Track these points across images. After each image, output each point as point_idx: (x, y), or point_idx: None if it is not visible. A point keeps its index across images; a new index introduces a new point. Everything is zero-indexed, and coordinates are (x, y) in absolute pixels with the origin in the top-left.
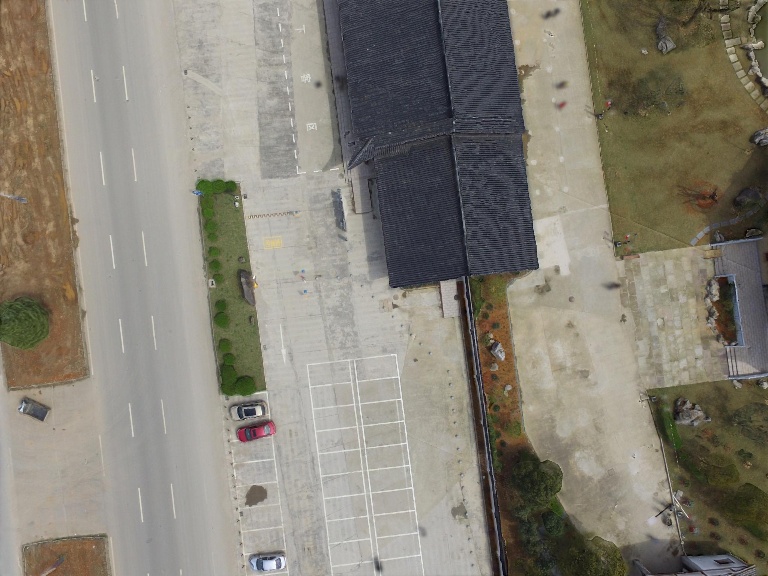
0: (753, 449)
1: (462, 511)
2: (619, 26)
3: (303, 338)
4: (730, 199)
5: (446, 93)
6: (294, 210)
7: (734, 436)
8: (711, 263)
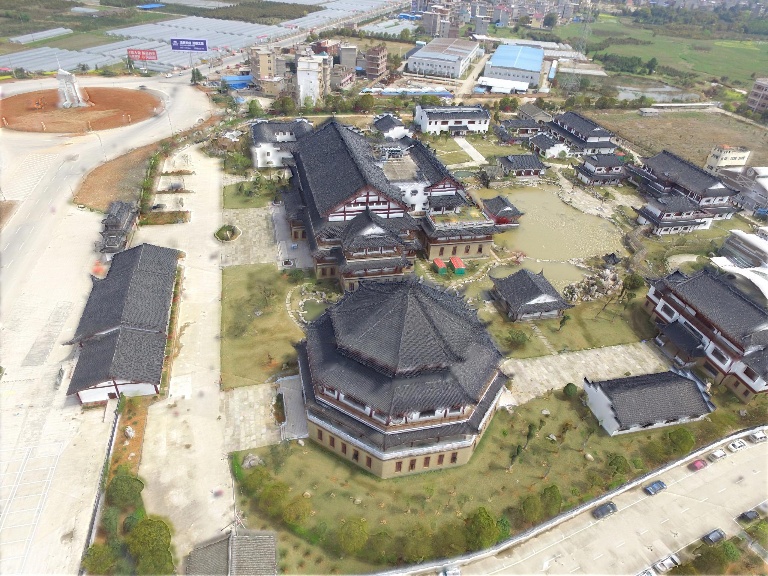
0: (294, 480)
1: (70, 537)
2: (238, 309)
3: (2, 437)
4: (286, 363)
5: None
6: (33, 378)
7: (282, 473)
8: (275, 390)
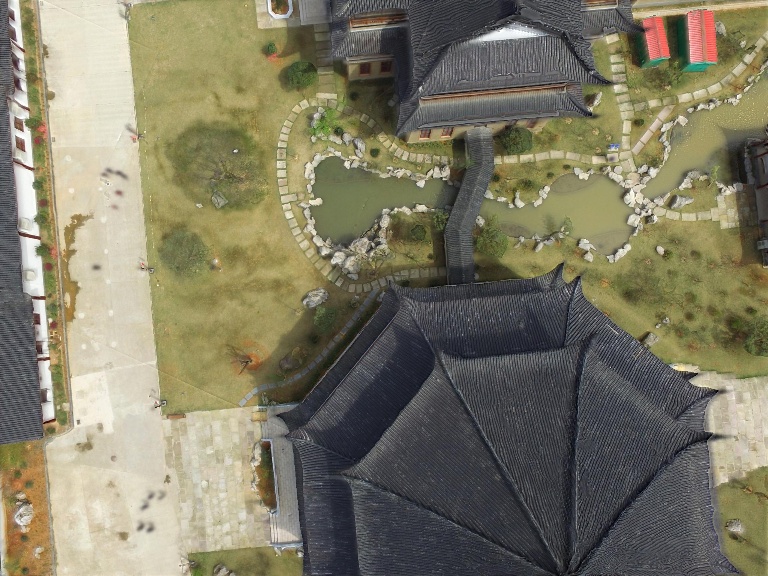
0: None
1: None
2: (176, 177)
3: None
4: (277, 361)
5: None
6: None
7: None
8: (258, 425)
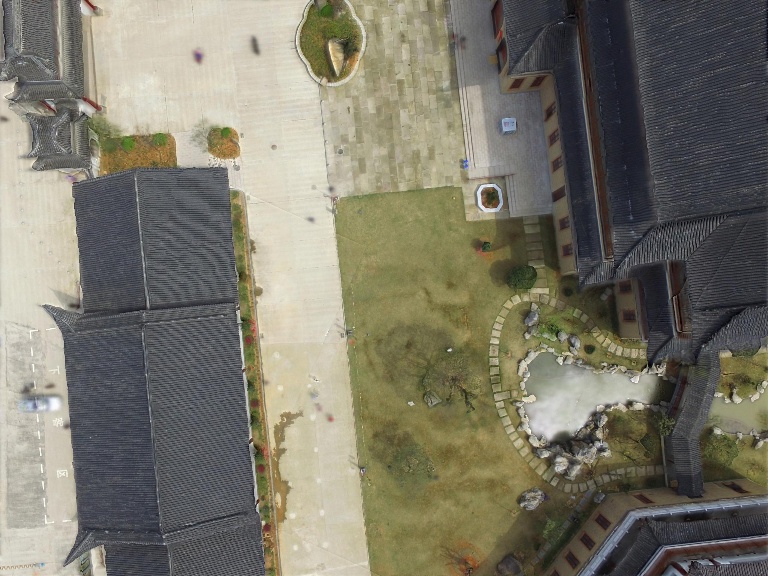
0: None
1: None
2: (386, 374)
3: None
4: (493, 564)
5: None
6: (40, 562)
7: None
8: None
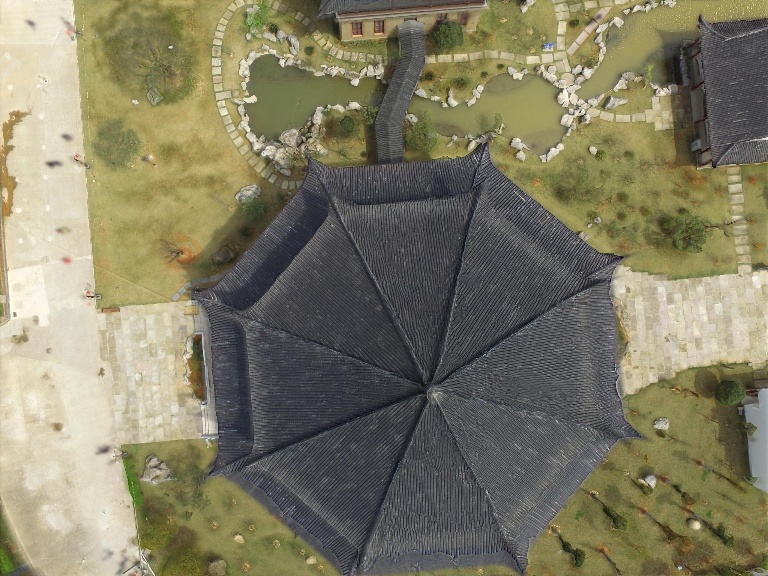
0: (221, 509)
1: None
2: (113, 74)
3: None
4: (209, 255)
5: None
6: None
7: None
8: (191, 319)
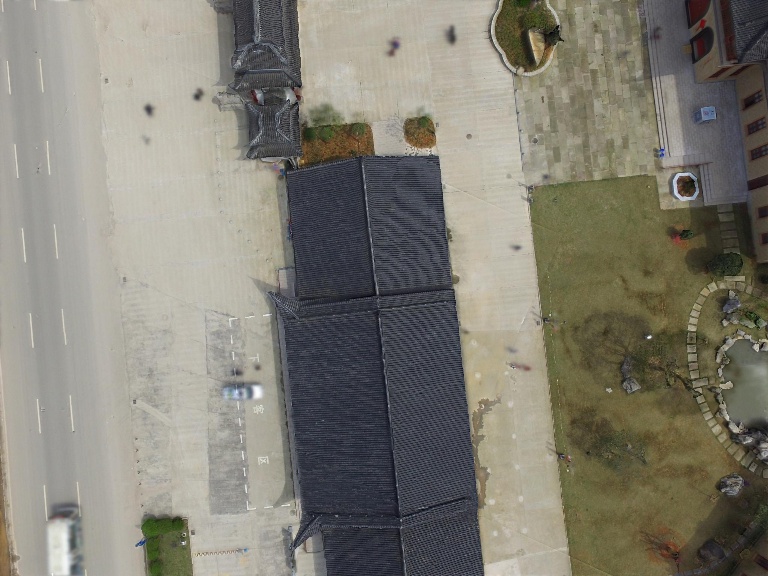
0: None
1: None
2: (583, 361)
3: None
4: (694, 549)
5: (394, 487)
6: (243, 548)
7: None
8: None
